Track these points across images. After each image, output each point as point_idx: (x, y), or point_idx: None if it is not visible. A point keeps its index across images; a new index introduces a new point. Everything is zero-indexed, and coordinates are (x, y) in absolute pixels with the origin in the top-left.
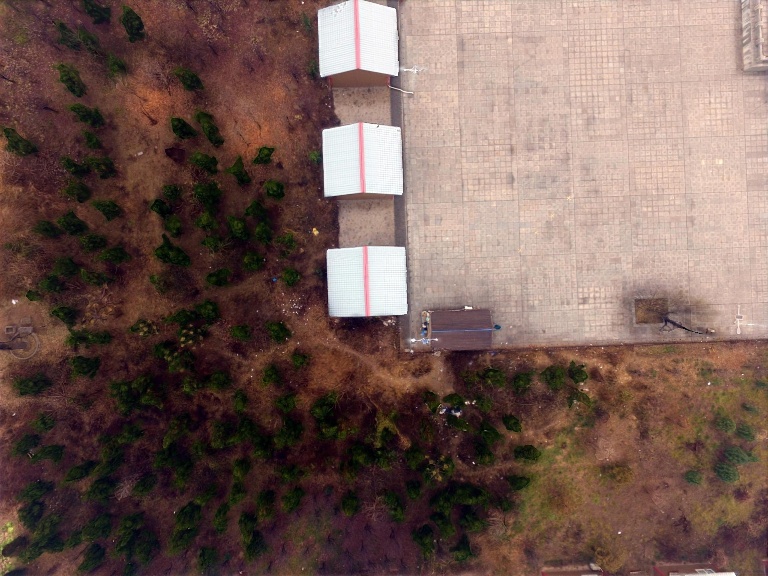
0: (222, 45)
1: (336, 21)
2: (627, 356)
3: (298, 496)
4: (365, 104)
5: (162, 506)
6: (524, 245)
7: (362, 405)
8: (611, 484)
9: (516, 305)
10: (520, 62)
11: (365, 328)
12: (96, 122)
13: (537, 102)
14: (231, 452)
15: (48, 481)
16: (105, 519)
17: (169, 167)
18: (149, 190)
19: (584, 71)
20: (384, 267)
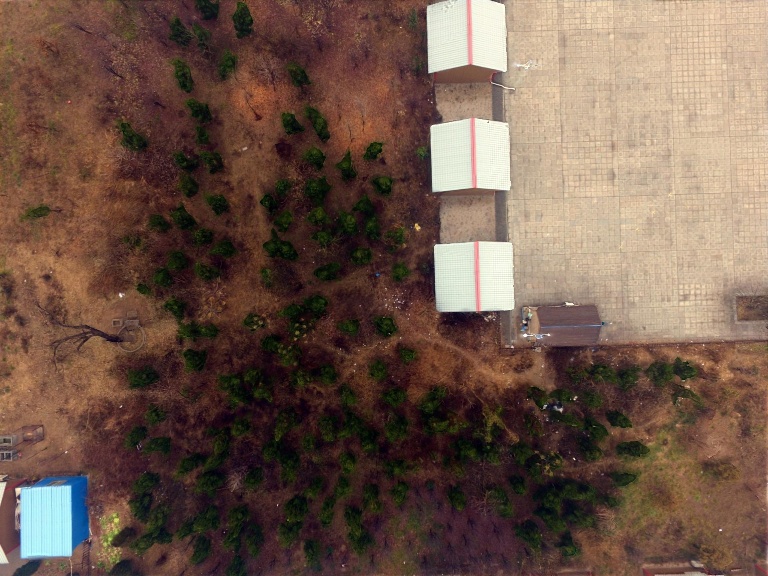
0: (326, 41)
1: (447, 17)
2: (729, 353)
3: (406, 490)
4: (467, 100)
5: (265, 499)
6: (625, 241)
7: (464, 400)
8: (713, 481)
9: (616, 301)
10: (622, 58)
11: (470, 323)
12: (205, 117)
13: (639, 98)
14: (334, 446)
15: (155, 473)
16: (214, 511)
17: (273, 162)
18: (253, 185)
19: (686, 67)
20: (493, 262)
